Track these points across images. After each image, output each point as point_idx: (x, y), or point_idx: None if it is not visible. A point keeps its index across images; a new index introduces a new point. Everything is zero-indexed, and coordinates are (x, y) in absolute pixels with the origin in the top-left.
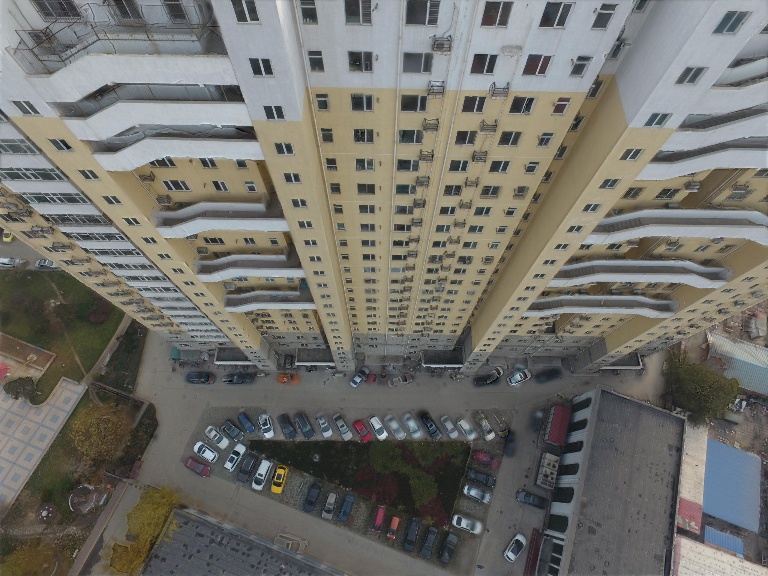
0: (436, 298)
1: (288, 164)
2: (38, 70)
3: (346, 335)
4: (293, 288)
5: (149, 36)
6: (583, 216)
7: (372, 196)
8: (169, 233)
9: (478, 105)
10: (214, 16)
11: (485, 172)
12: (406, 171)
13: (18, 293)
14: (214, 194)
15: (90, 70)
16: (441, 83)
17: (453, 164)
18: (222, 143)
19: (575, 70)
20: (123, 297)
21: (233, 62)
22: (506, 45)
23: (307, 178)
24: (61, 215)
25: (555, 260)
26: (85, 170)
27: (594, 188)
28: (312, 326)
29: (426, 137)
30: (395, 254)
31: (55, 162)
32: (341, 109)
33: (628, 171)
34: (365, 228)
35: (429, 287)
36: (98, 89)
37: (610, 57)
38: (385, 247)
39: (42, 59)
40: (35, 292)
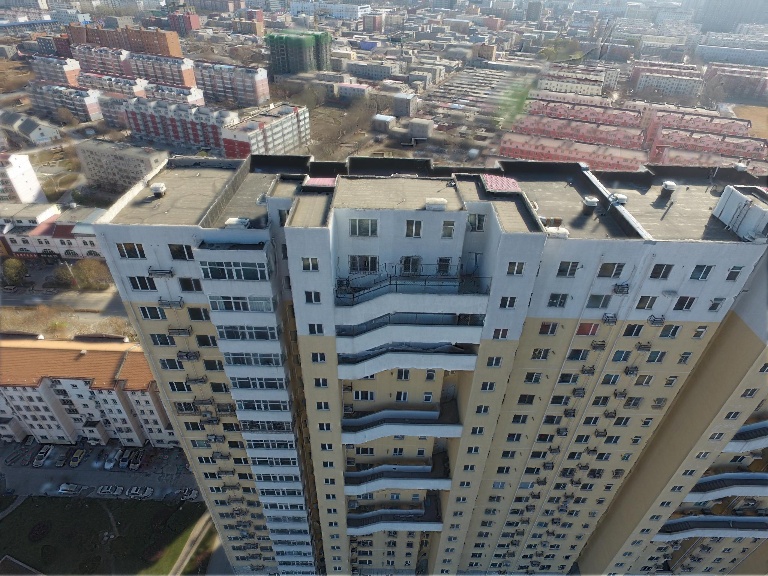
0: (556, 520)
1: (491, 374)
2: (338, 303)
3: (456, 568)
4: (414, 507)
5: (426, 283)
6: (725, 423)
7: (529, 406)
8: (350, 439)
9: (636, 331)
10: (484, 271)
11: (632, 385)
12: (565, 384)
13: (71, 524)
14: (393, 404)
15: (385, 303)
16: (613, 315)
17: (606, 378)
18: (447, 357)
19: (711, 307)
20: (232, 518)
21: (490, 299)
22: (665, 290)
23: (501, 386)
24: (254, 422)
25: (694, 470)
26: (320, 378)
27: (737, 396)
28: (410, 559)
29: (590, 355)
30: (530, 466)
31: (303, 371)
32: (531, 333)
33: (765, 382)
34: (510, 438)
35: (551, 506)
36: (381, 316)
37: (734, 299)
38: (523, 459)
39: (339, 296)
40: (90, 523)
